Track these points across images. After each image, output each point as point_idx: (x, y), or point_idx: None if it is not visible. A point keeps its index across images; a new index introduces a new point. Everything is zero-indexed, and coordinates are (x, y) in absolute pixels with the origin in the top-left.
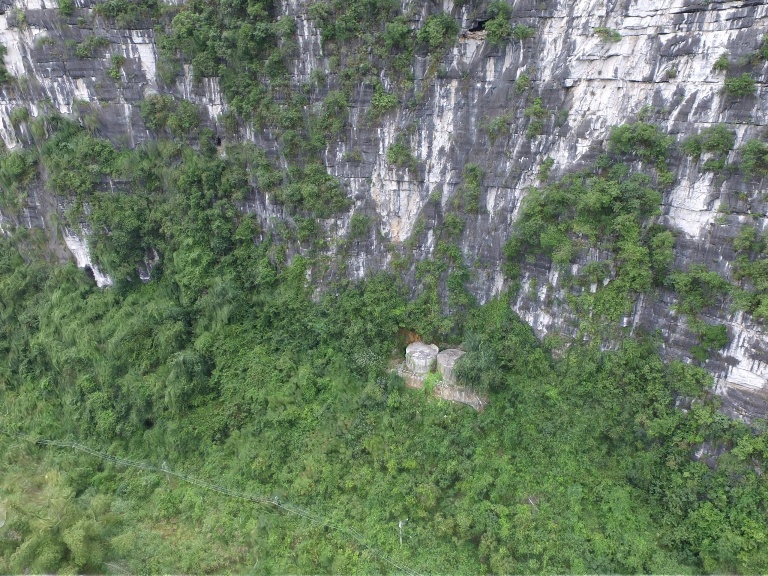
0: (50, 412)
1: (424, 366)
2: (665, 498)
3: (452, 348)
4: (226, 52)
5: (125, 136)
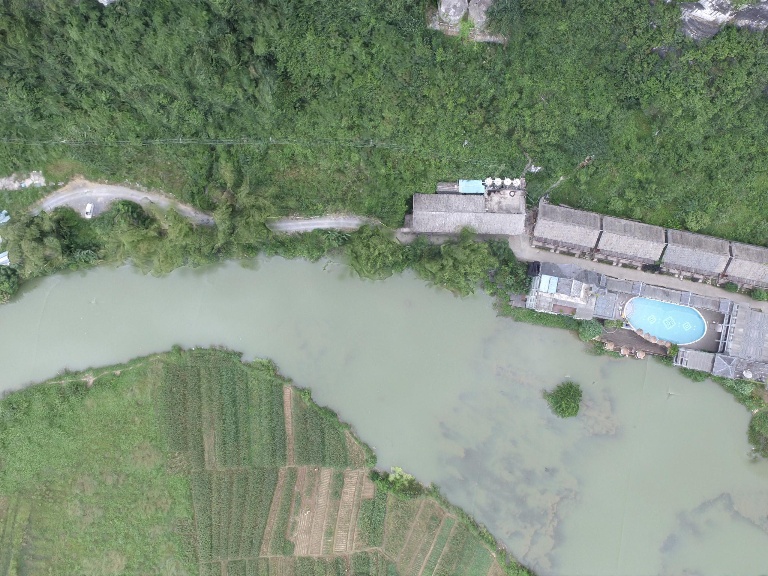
0: (131, 118)
1: (458, 19)
2: (627, 74)
3: None
4: None
5: None
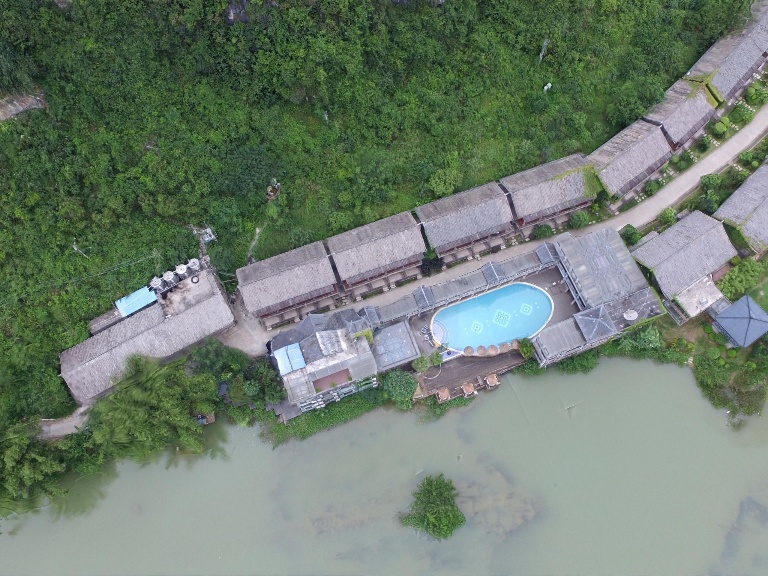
0: None
1: None
2: (232, 68)
3: None
4: None
5: None
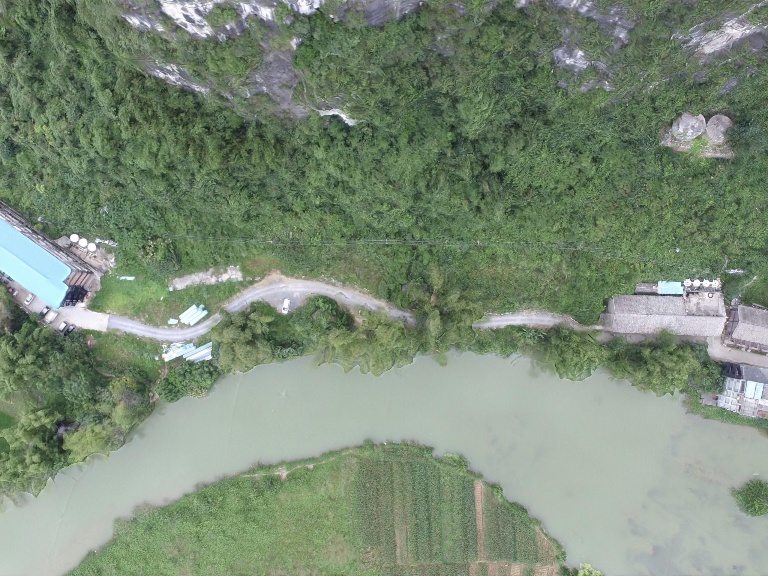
0: (339, 220)
1: None
2: None
3: (715, 114)
4: None
5: (391, 15)
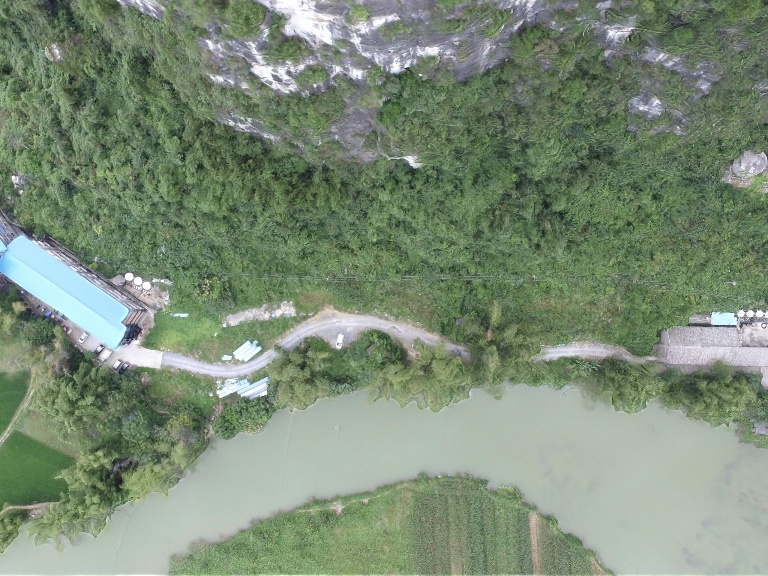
0: (395, 256)
1: None
2: None
3: None
4: (697, 19)
5: None
